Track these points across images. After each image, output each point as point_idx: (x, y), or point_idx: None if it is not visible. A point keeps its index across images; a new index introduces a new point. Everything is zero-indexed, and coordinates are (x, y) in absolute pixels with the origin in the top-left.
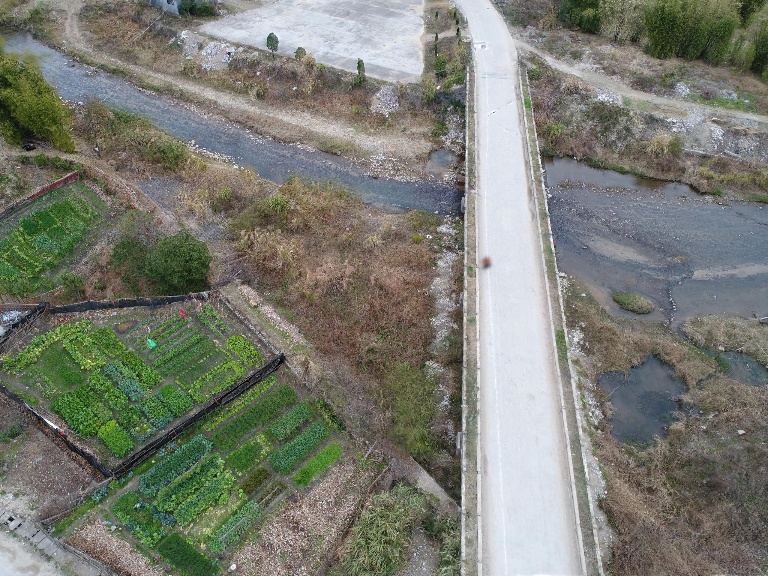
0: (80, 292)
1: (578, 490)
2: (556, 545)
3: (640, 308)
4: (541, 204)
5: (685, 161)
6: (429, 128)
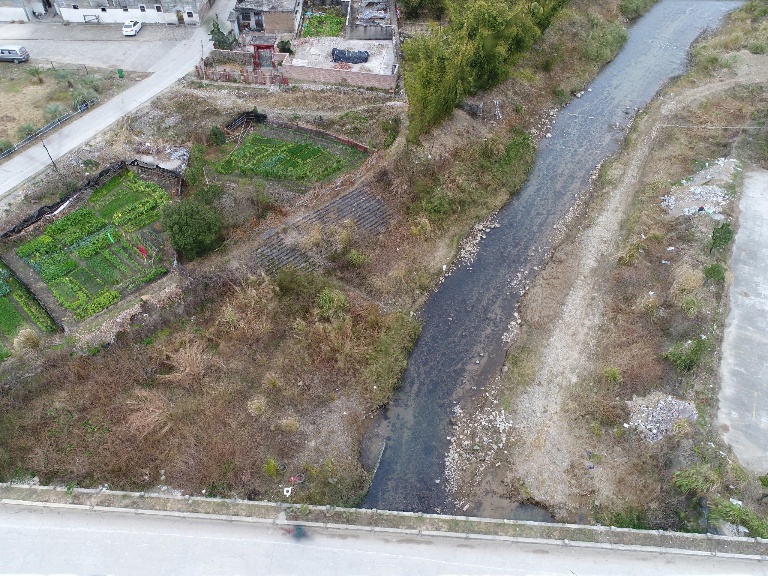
0: None
1: None
2: None
3: None
4: None
5: None
6: (611, 498)
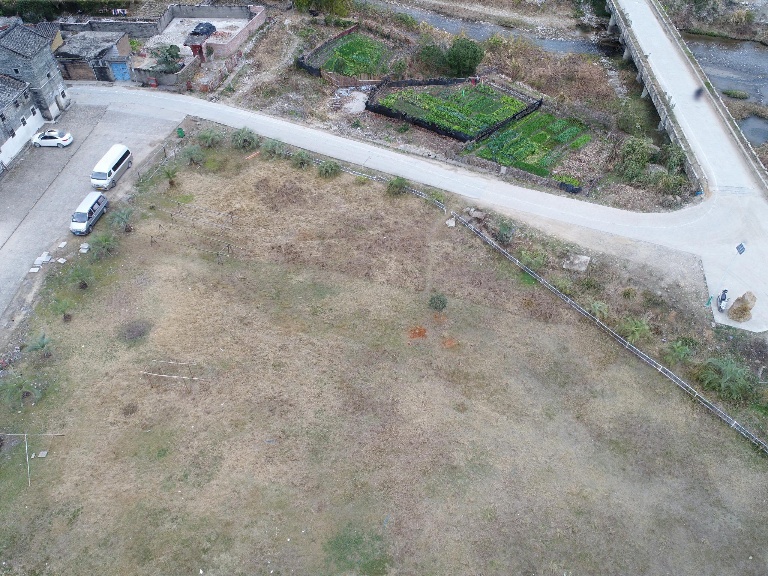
0: None
1: (736, 133)
2: (729, 152)
3: (741, 96)
4: (675, 34)
5: (756, 28)
6: (571, 12)
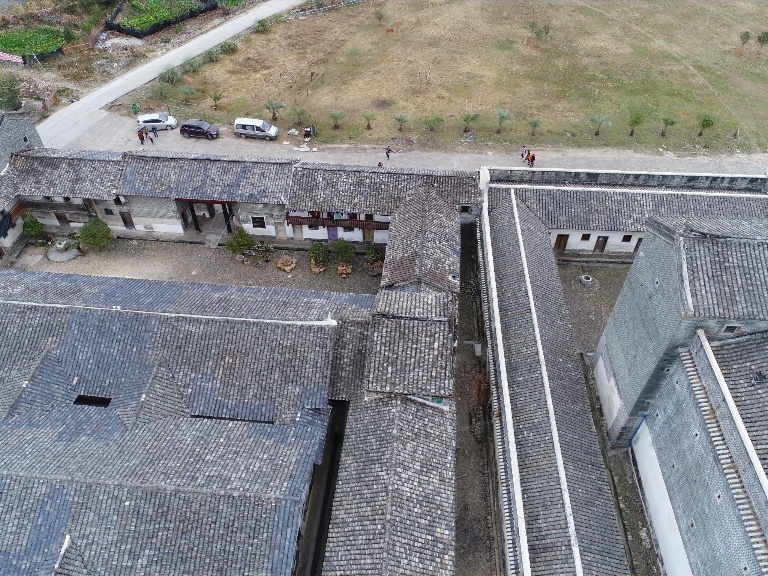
0: None
1: None
2: None
3: None
4: None
5: None
6: None
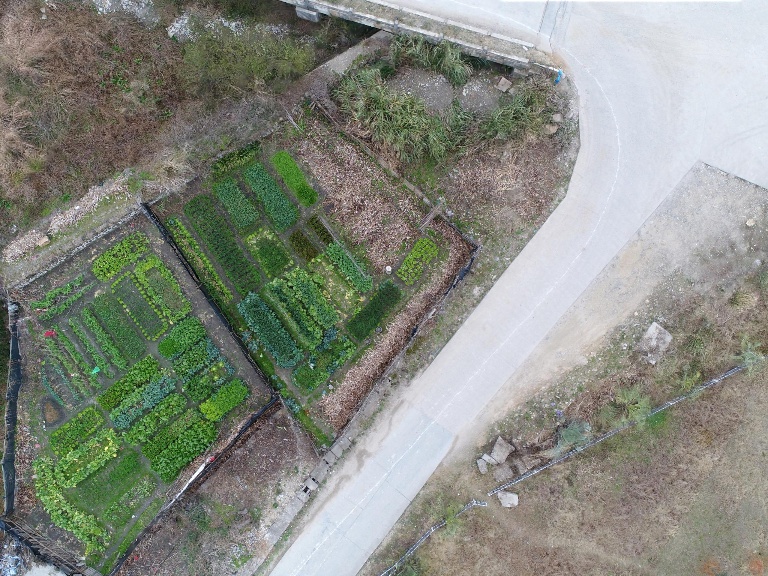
0: None
1: None
2: None
3: None
4: None
5: None
6: None
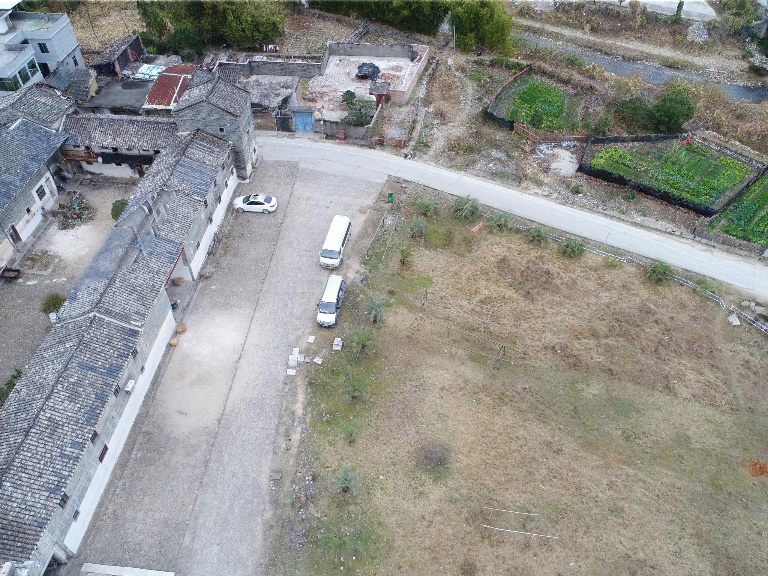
0: (602, 132)
1: None
2: None
3: None
4: None
5: None
6: (739, 52)
